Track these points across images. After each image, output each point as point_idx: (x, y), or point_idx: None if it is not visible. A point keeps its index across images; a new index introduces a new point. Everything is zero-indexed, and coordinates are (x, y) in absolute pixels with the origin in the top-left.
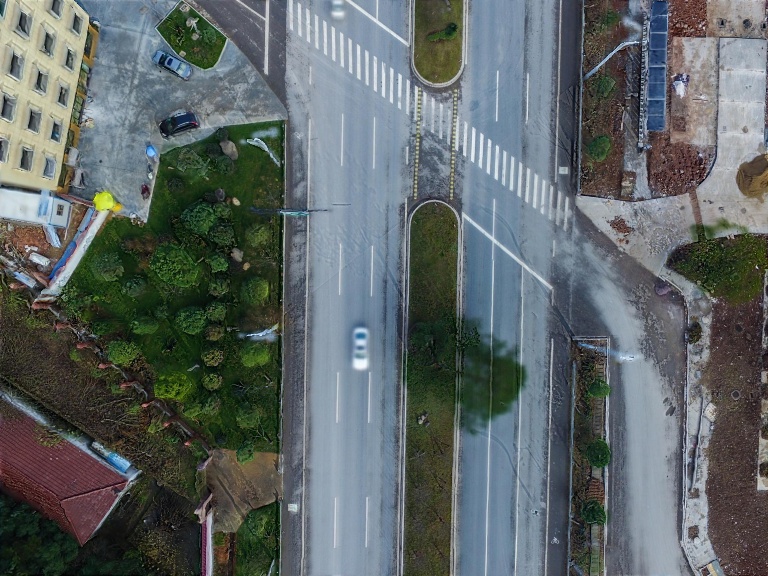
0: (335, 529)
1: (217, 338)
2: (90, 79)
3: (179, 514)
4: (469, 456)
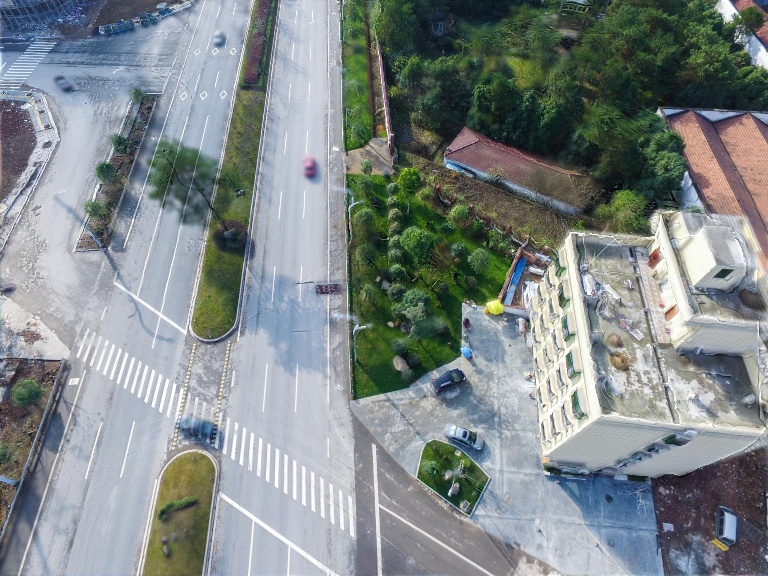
0: (307, 140)
1: None
2: None
3: (411, 146)
4: (208, 177)
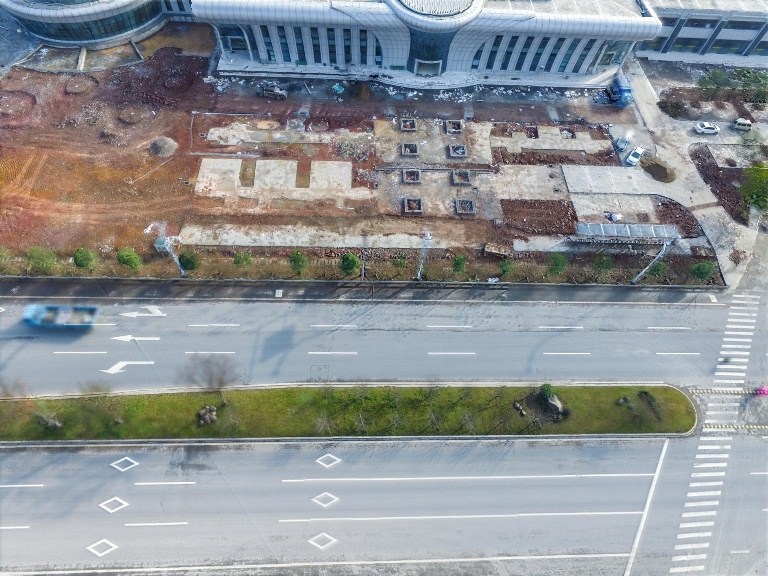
0: None
1: None
2: None
3: None
4: None
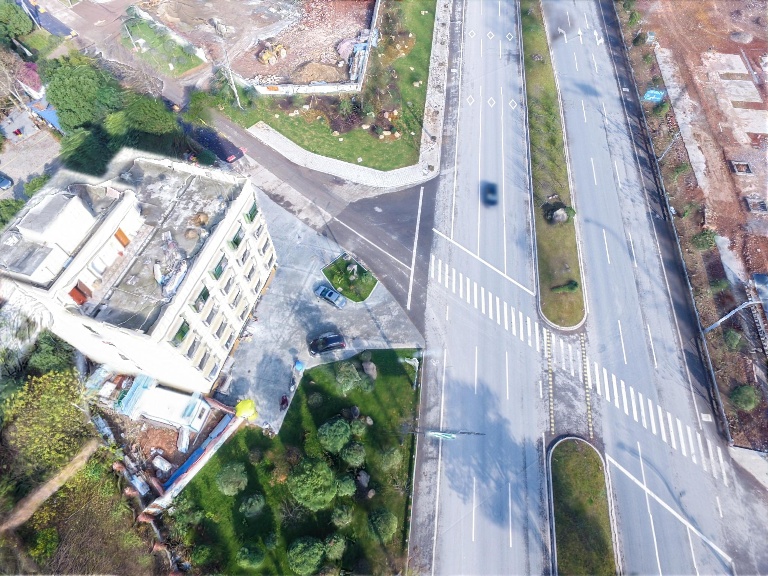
0: None
1: None
2: (259, 303)
3: None
4: None
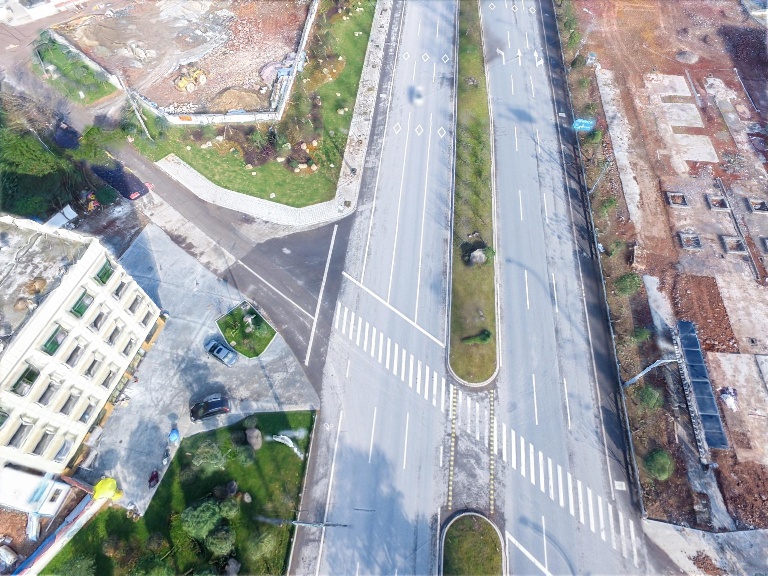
0: None
1: None
2: (142, 361)
3: None
4: None
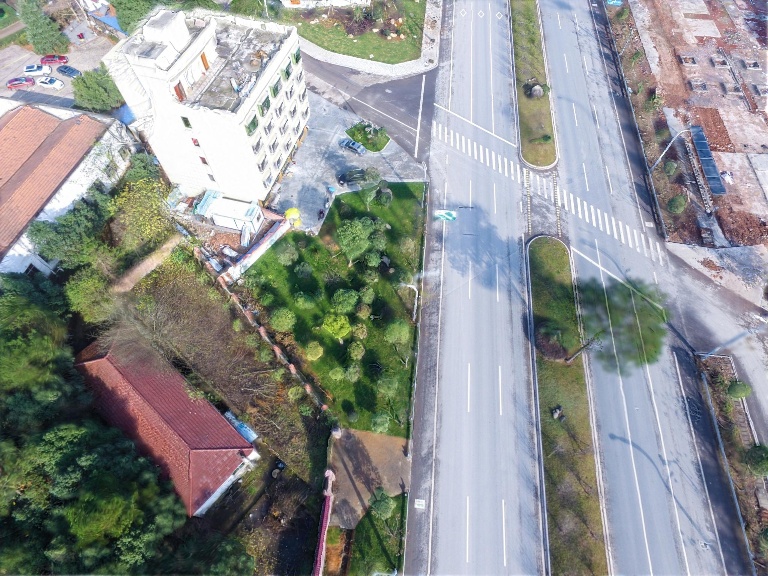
0: (467, 537)
1: (365, 316)
2: (296, 153)
3: (295, 500)
4: (612, 463)
